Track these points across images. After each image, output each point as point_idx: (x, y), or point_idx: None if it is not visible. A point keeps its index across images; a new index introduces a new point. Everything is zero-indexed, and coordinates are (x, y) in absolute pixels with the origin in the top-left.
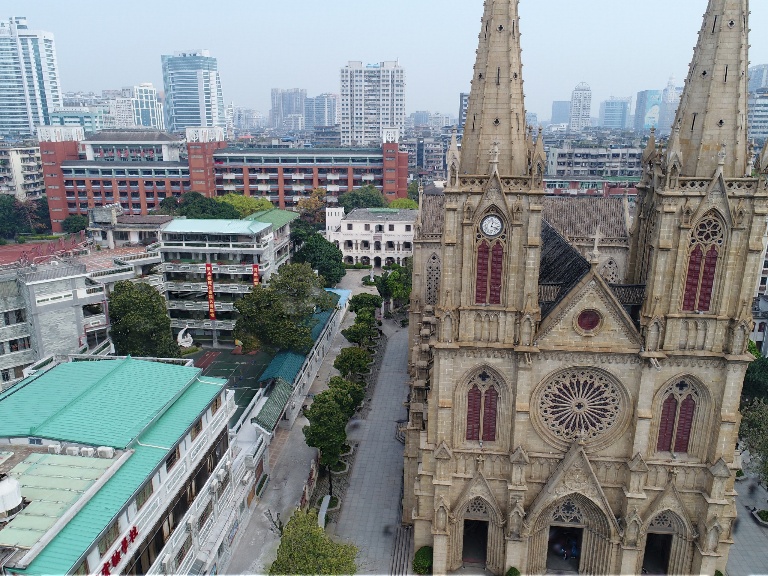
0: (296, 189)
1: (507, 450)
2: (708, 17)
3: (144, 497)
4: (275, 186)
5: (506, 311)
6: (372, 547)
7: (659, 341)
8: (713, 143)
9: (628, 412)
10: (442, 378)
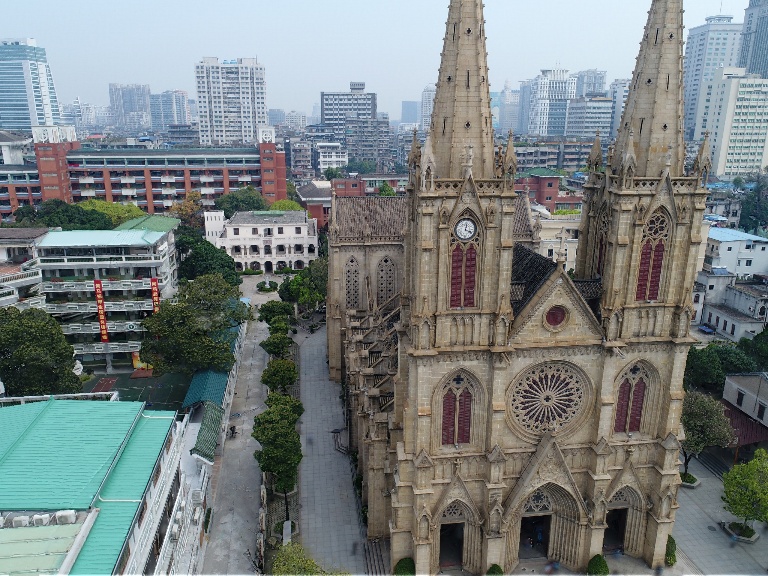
0: (166, 193)
1: (483, 450)
2: (651, 29)
3: (123, 562)
4: (142, 190)
5: (481, 313)
6: (343, 568)
7: (618, 331)
8: (659, 146)
9: (591, 400)
10: (421, 386)
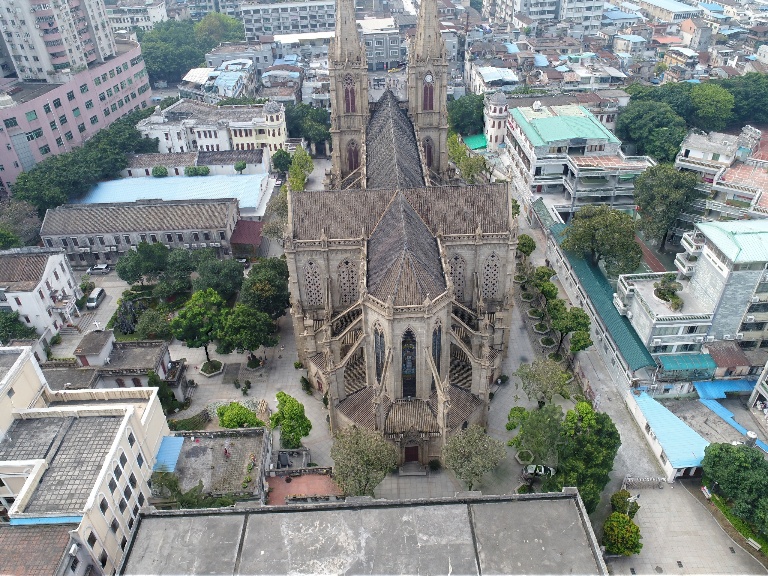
0: None
1: None
2: None
3: None
4: None
5: None
6: None
7: None
8: None
9: None
10: None
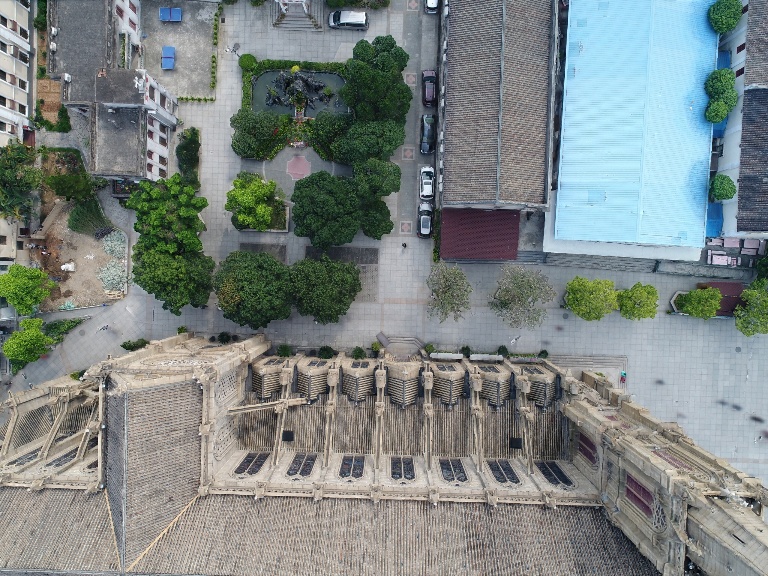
0: None
1: None
2: None
3: None
4: None
5: None
6: None
7: None
8: None
9: None
10: None
